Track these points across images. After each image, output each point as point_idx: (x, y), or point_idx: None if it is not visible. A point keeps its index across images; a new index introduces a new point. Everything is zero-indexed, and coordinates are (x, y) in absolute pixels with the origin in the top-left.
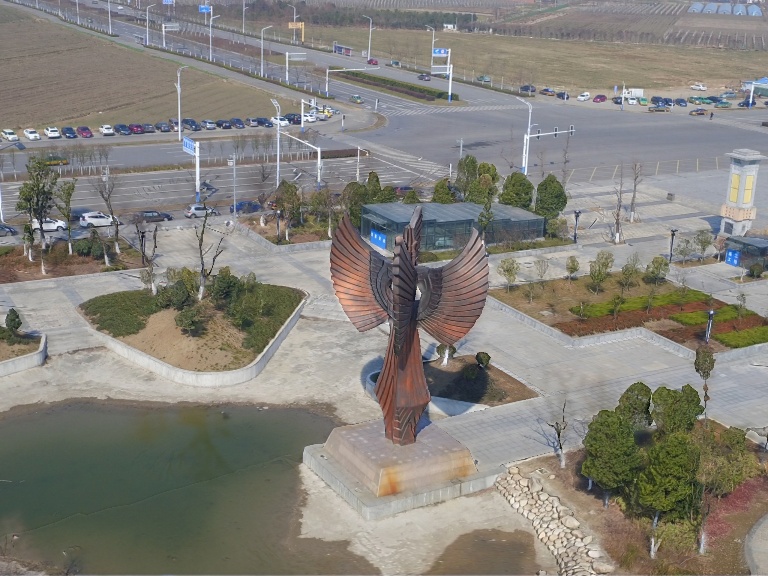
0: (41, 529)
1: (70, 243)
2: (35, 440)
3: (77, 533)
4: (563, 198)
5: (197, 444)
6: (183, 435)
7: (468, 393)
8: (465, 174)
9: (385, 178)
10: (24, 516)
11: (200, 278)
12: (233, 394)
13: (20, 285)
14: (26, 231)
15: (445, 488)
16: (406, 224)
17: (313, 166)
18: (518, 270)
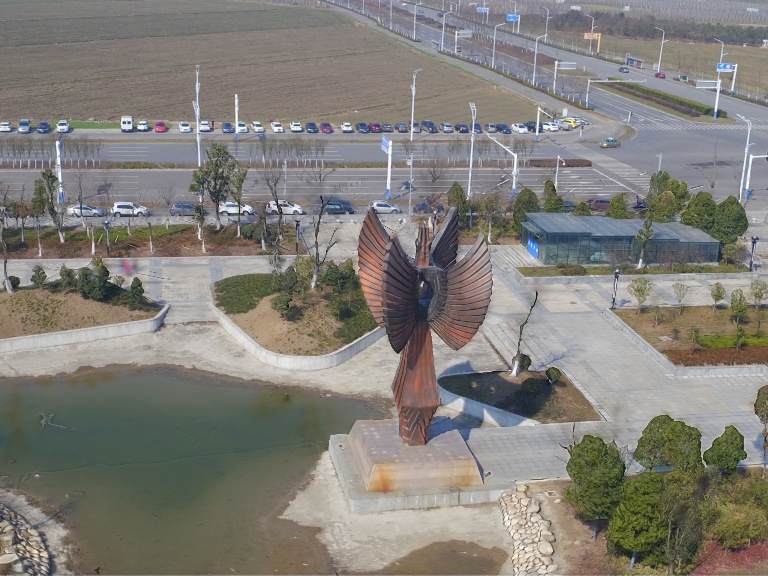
0: (64, 472)
1: (239, 226)
2: (109, 396)
3: (90, 480)
4: (743, 222)
5: (246, 419)
6: (238, 409)
7: (524, 407)
8: (656, 190)
9: (591, 190)
10: (58, 459)
11: (314, 267)
12: (306, 379)
13: (178, 259)
14: (197, 211)
15: (441, 494)
16: (557, 235)
17: None
18: (651, 291)
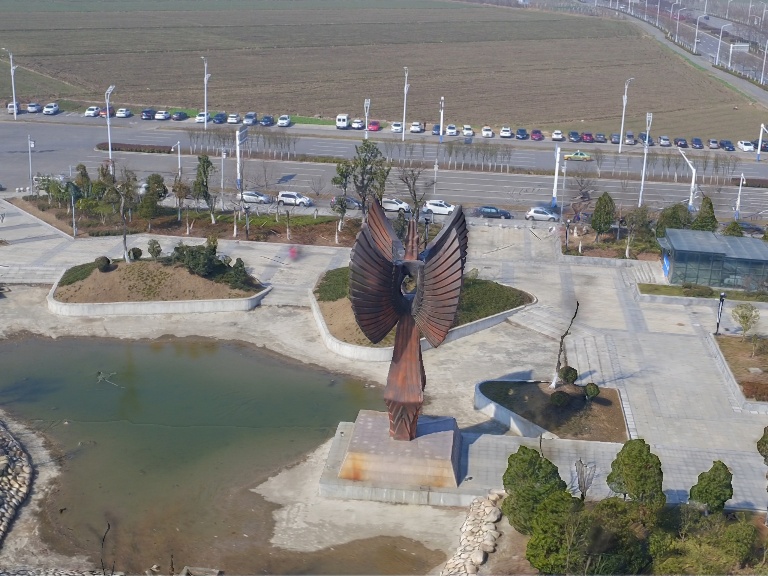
0: (92, 423)
1: None
2: (173, 362)
3: (108, 433)
4: None
5: (282, 399)
6: (281, 389)
7: (548, 419)
8: None
9: None
10: (94, 411)
11: None
12: (361, 368)
13: (308, 247)
14: (338, 203)
15: (410, 491)
16: (686, 253)
17: (720, 192)
18: (757, 319)
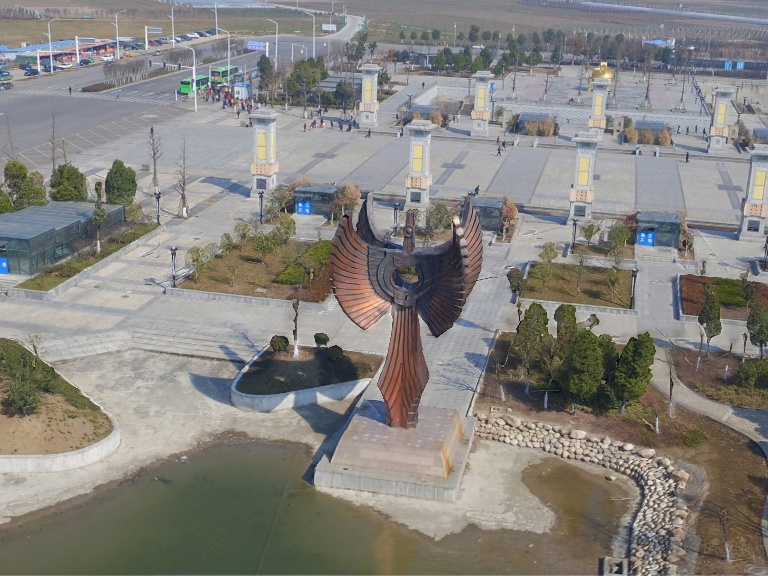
0: None
1: None
2: None
3: None
4: None
5: (189, 517)
6: (161, 515)
7: (344, 373)
8: None
9: None
10: None
11: None
12: (131, 459)
13: None
14: None
15: (466, 450)
16: (35, 239)
17: None
18: None
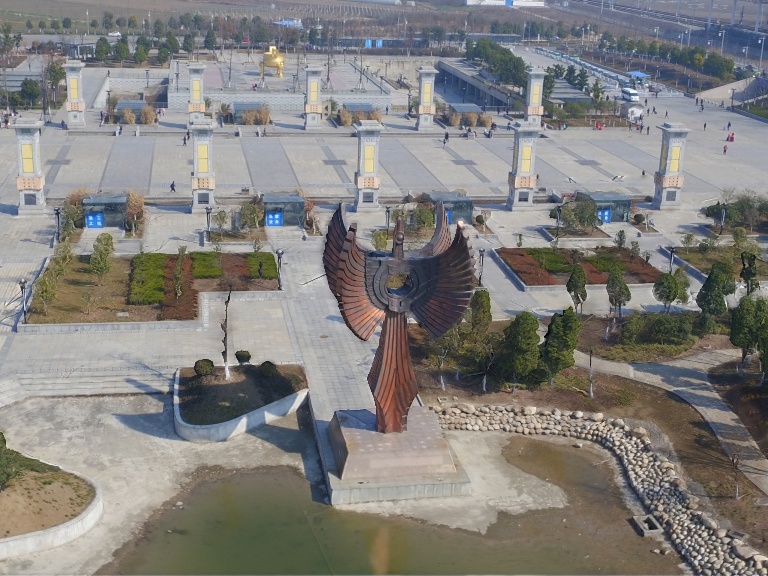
0: None
1: None
2: None
3: None
4: None
5: (234, 563)
6: (205, 568)
7: (281, 388)
8: None
9: None
10: None
11: None
12: (126, 516)
13: None
14: None
15: None
16: None
17: None
18: None
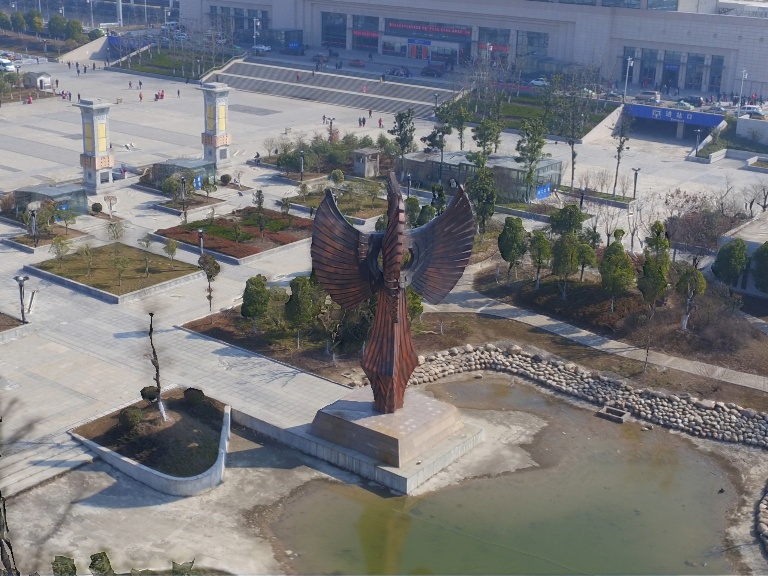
0: None
1: None
2: None
3: (670, 574)
4: None
5: None
6: None
7: None
8: None
9: None
10: None
11: None
12: None
13: None
14: None
15: None
16: None
17: None
18: None
